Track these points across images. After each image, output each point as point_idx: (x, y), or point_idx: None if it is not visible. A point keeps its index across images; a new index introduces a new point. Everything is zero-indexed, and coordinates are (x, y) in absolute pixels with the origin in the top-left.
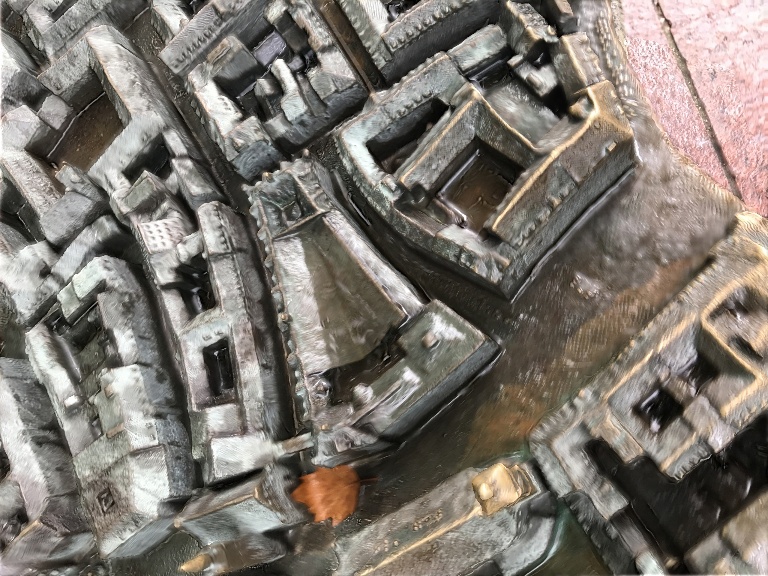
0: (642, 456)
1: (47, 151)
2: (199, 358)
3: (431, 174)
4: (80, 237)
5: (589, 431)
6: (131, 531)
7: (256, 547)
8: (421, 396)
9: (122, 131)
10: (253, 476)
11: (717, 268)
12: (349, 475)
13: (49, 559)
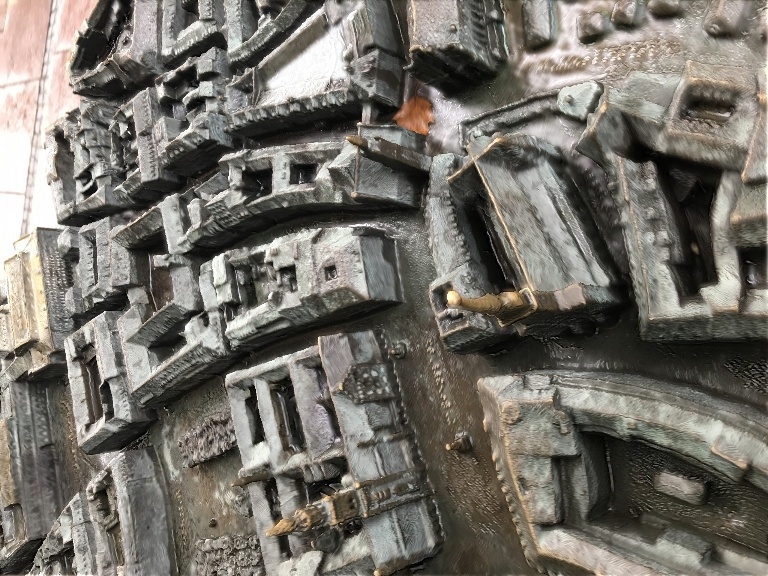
0: None
1: None
2: (292, 186)
3: None
4: (200, 280)
5: None
6: (358, 261)
7: None
8: (366, 12)
9: None
10: None
11: None
12: (410, 105)
13: (358, 363)
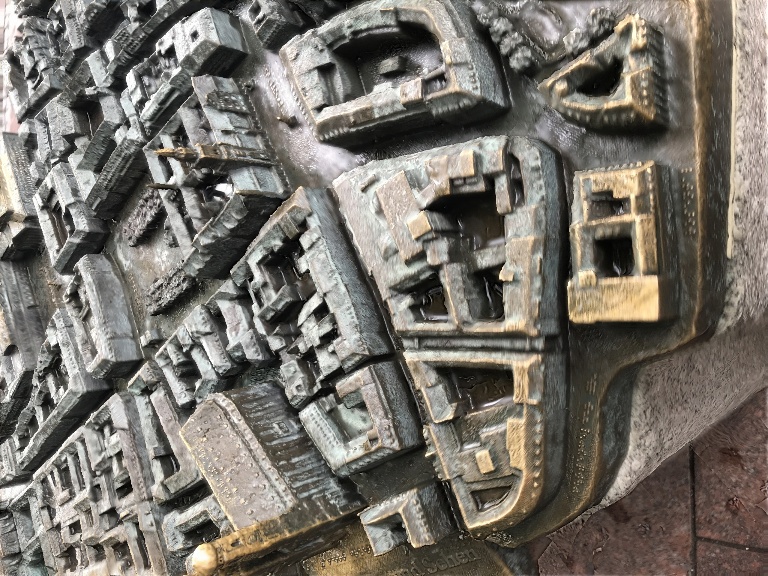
0: None
1: None
2: None
3: None
4: (120, 99)
5: None
6: (211, 23)
7: None
8: None
9: (90, 68)
10: None
11: None
12: None
13: None
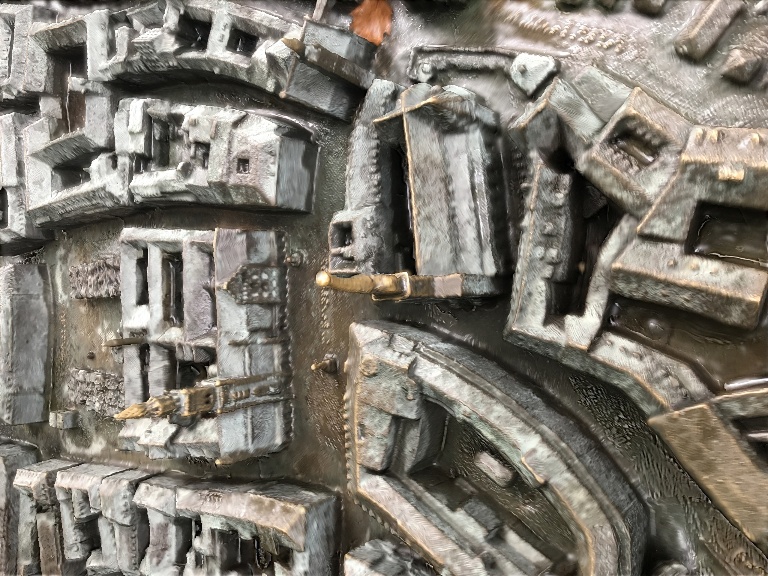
0: None
1: None
2: (227, 53)
3: None
4: (115, 117)
5: None
6: (273, 164)
7: None
8: None
9: (87, 36)
10: None
11: None
12: (372, 4)
13: (251, 263)
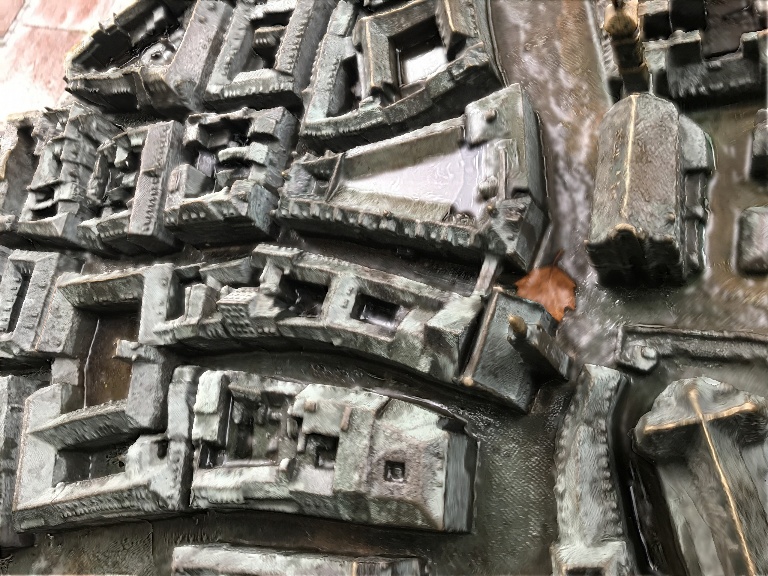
0: (672, 18)
1: None
2: (354, 322)
3: (385, 72)
4: (171, 390)
5: None
6: (440, 470)
7: None
8: (524, 145)
9: (143, 292)
10: (482, 317)
11: None
12: (542, 274)
13: None
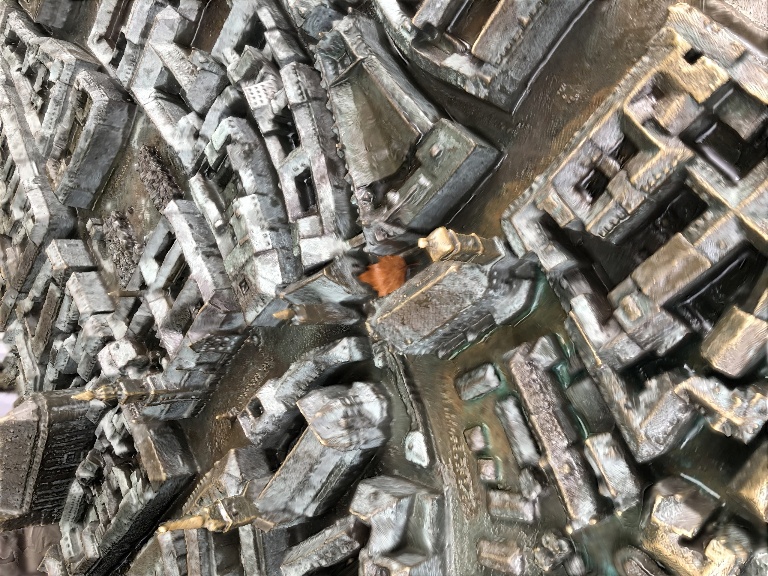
0: None
1: (190, 40)
2: (292, 185)
3: (436, 12)
4: (213, 105)
5: (536, 206)
6: (261, 306)
7: (333, 311)
8: (432, 195)
9: None
10: (329, 264)
11: (644, 59)
12: (400, 263)
13: (221, 329)
